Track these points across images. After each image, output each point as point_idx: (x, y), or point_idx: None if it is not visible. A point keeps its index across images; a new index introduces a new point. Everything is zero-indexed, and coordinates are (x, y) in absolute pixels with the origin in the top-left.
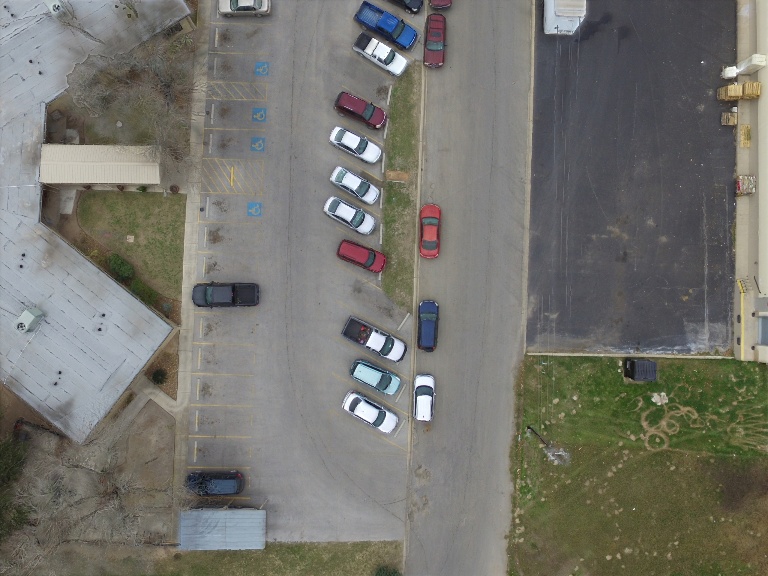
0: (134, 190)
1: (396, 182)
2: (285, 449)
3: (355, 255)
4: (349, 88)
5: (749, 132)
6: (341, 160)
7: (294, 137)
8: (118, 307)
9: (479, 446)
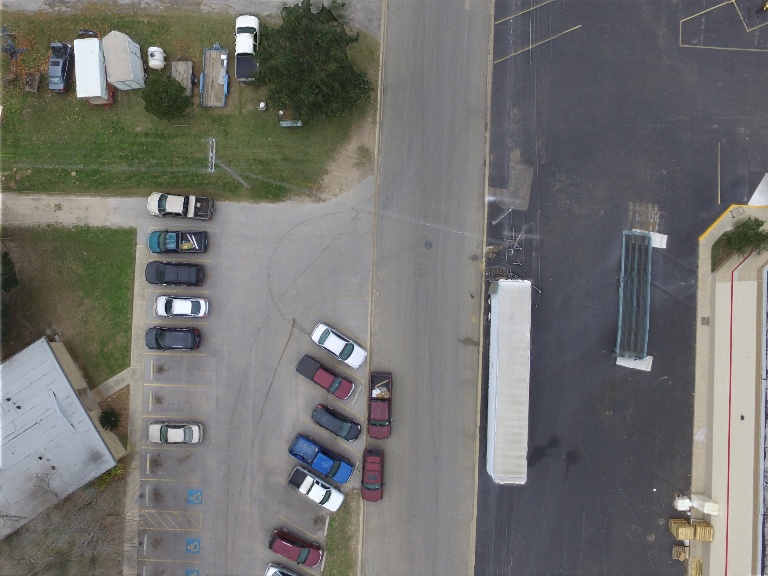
0: None
1: None
2: None
3: None
4: (285, 518)
5: (701, 566)
6: None
7: (229, 569)
8: None
9: None
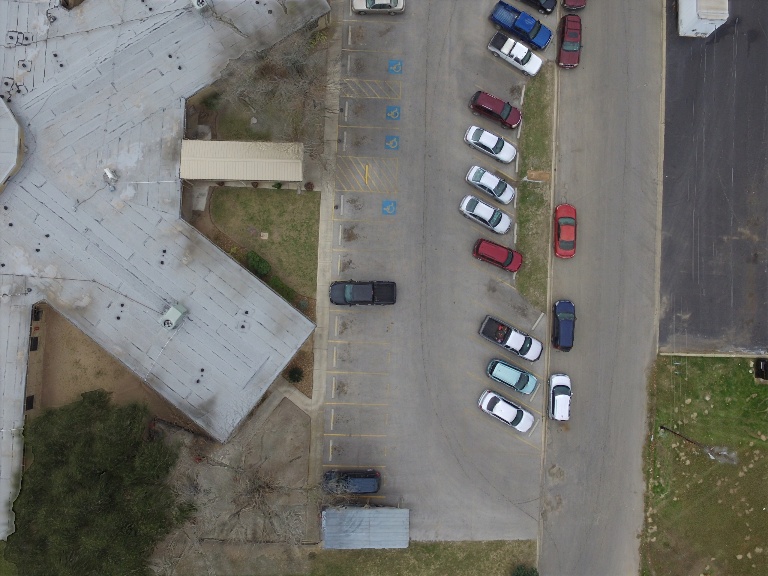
0: (268, 187)
1: (530, 182)
2: (420, 448)
3: (495, 254)
4: (483, 87)
5: None
6: (475, 159)
7: (428, 136)
8: (261, 304)
9: (613, 446)
